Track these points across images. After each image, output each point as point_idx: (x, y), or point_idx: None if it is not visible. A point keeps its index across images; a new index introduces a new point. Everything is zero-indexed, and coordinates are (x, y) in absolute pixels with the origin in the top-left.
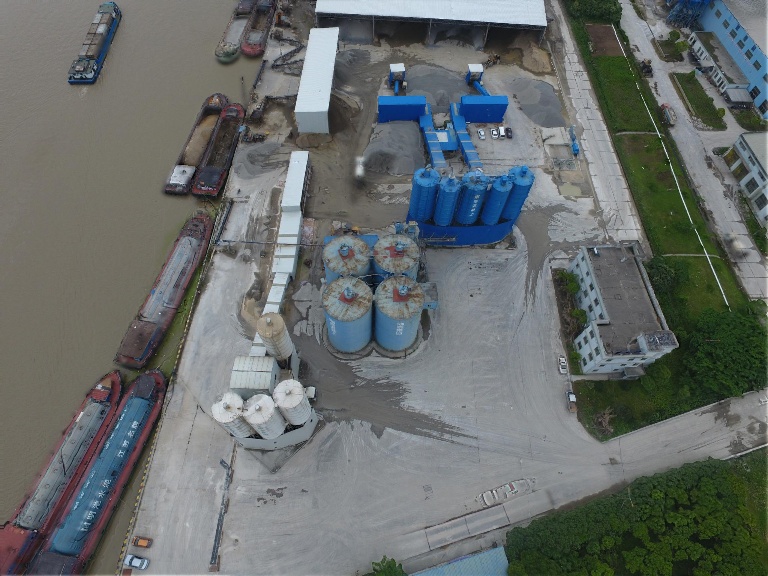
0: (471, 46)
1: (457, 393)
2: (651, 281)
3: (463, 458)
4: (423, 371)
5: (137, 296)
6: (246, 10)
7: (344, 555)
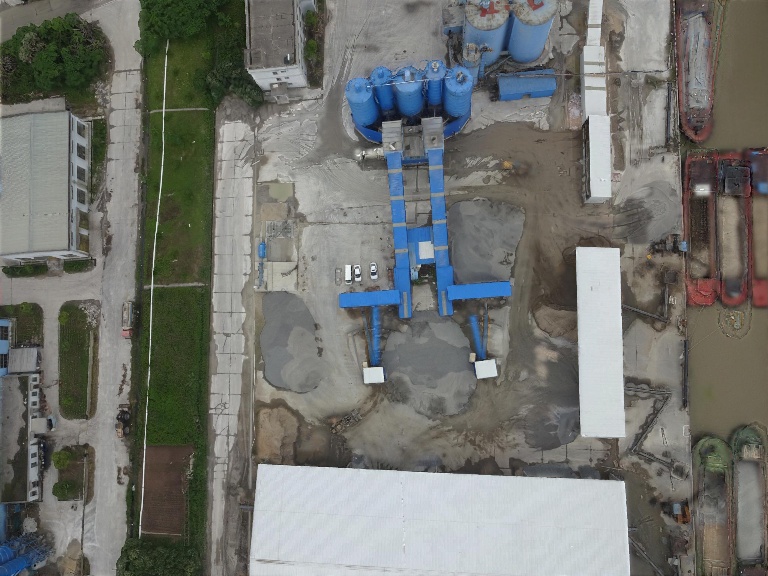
0: (370, 467)
1: None
2: (233, 65)
3: None
4: None
5: (733, 28)
6: (748, 559)
7: None
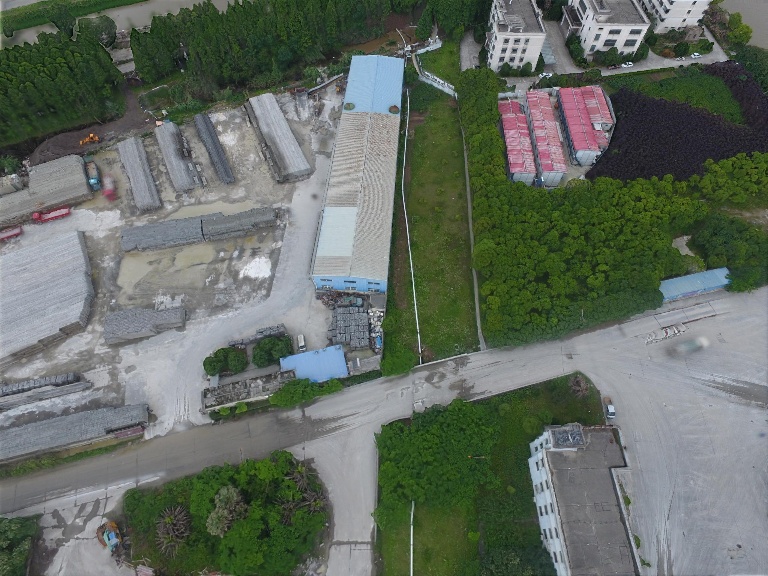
0: None
1: (721, 419)
2: (520, 559)
3: (700, 362)
4: (763, 443)
5: None
6: None
7: (767, 302)
